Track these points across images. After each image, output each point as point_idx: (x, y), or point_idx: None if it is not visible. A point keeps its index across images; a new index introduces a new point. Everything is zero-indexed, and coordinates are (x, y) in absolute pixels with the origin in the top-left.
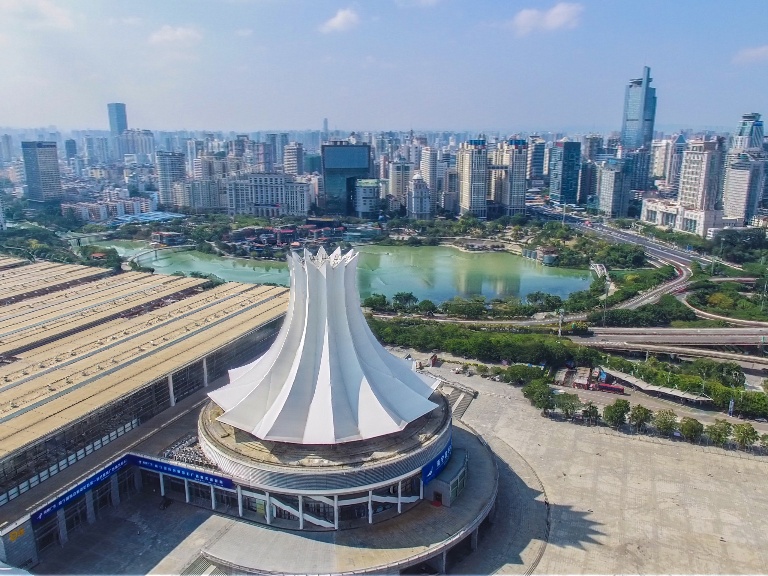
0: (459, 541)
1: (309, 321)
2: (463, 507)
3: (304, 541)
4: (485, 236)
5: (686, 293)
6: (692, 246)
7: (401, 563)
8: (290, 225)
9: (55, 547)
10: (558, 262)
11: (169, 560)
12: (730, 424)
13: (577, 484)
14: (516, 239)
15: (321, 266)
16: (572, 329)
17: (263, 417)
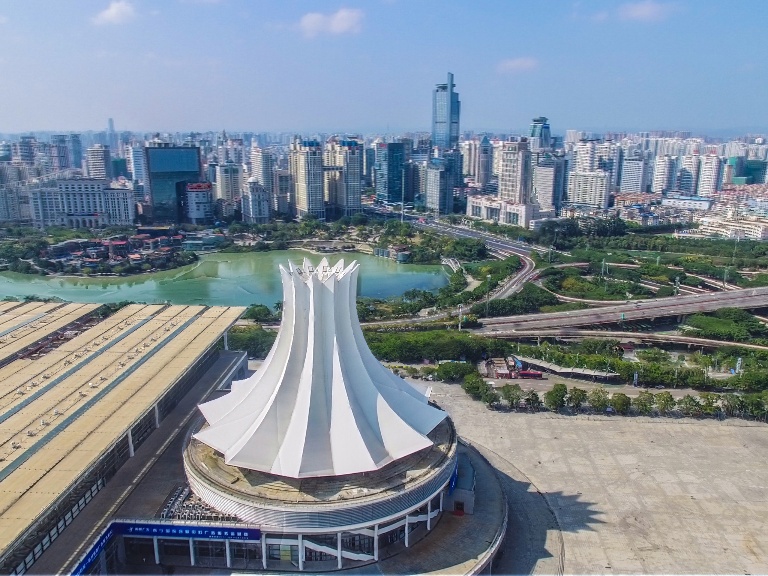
0: (499, 547)
1: (315, 341)
2: (485, 512)
3: None
4: (332, 237)
5: (539, 280)
6: (522, 237)
7: None
8: (119, 236)
9: None
10: (412, 259)
11: None
12: (652, 394)
13: (554, 470)
14: (364, 239)
15: (327, 280)
16: (464, 322)
17: (278, 453)
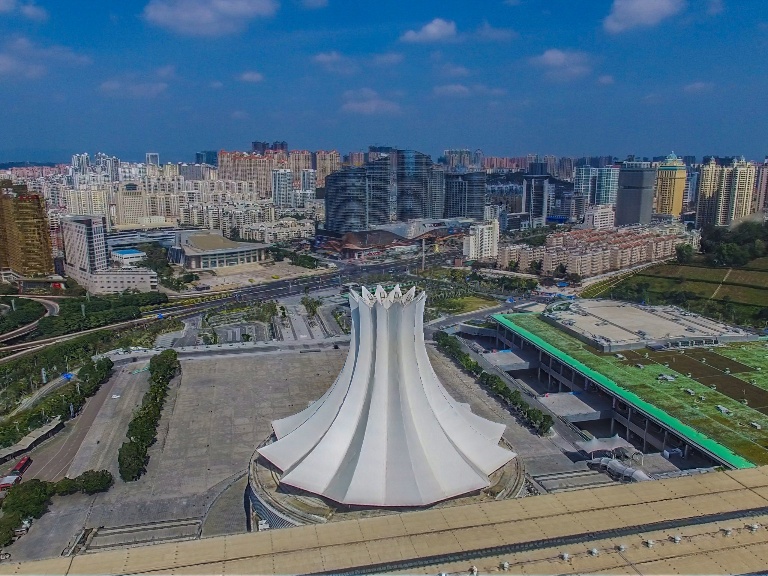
0: None
1: None
2: None
3: None
4: None
5: None
6: None
7: None
8: None
9: None
10: None
11: None
12: None
13: None
14: None
15: None
16: None
17: None
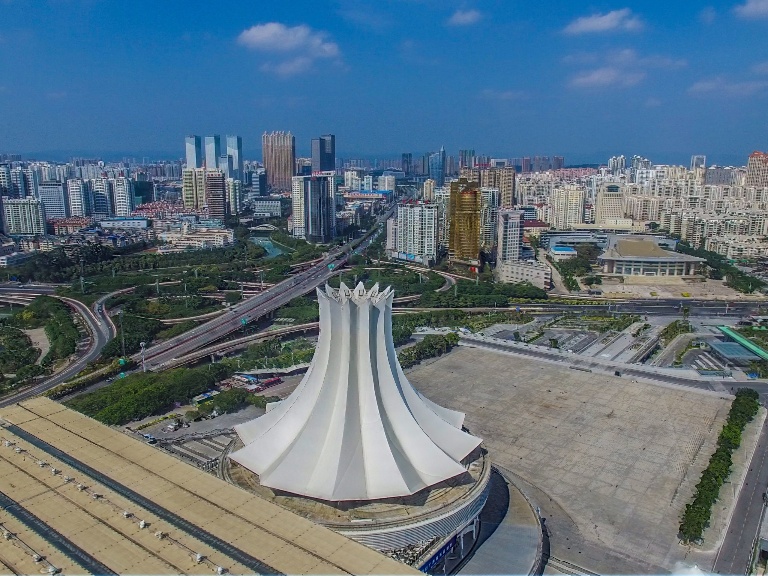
0: None
1: None
2: None
3: (494, 539)
4: None
5: (111, 312)
6: (14, 276)
7: None
8: None
9: None
10: None
11: None
12: None
13: None
14: None
15: (388, 298)
16: (122, 366)
17: (416, 469)
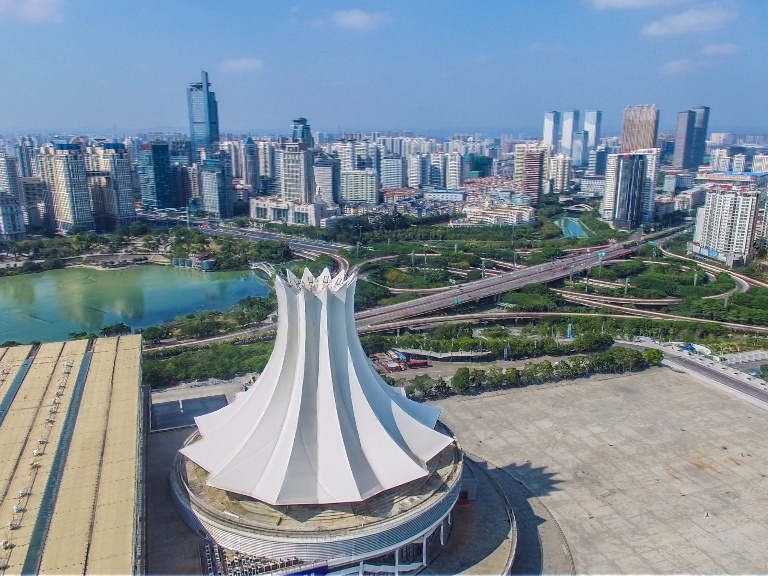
0: None
1: (331, 356)
2: (485, 495)
3: None
4: (115, 250)
5: (361, 276)
6: (321, 236)
7: (511, 562)
8: None
9: None
10: (219, 266)
11: None
12: (536, 364)
13: (496, 445)
14: (154, 249)
15: (339, 290)
16: None
17: (318, 481)
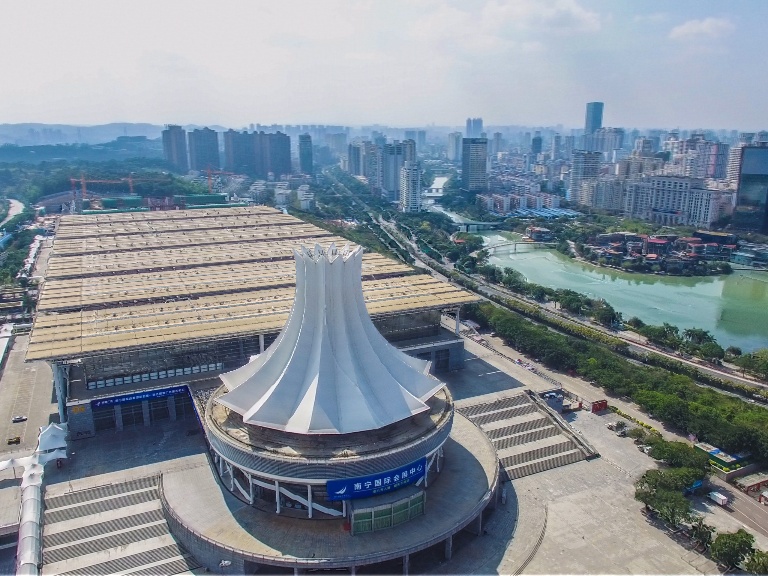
0: (318, 567)
1: (295, 309)
2: (363, 542)
3: (219, 500)
4: None
5: None
6: None
7: (246, 554)
8: (671, 235)
9: (113, 431)
10: None
11: (141, 468)
12: None
13: None
14: None
15: None
16: None
17: None
